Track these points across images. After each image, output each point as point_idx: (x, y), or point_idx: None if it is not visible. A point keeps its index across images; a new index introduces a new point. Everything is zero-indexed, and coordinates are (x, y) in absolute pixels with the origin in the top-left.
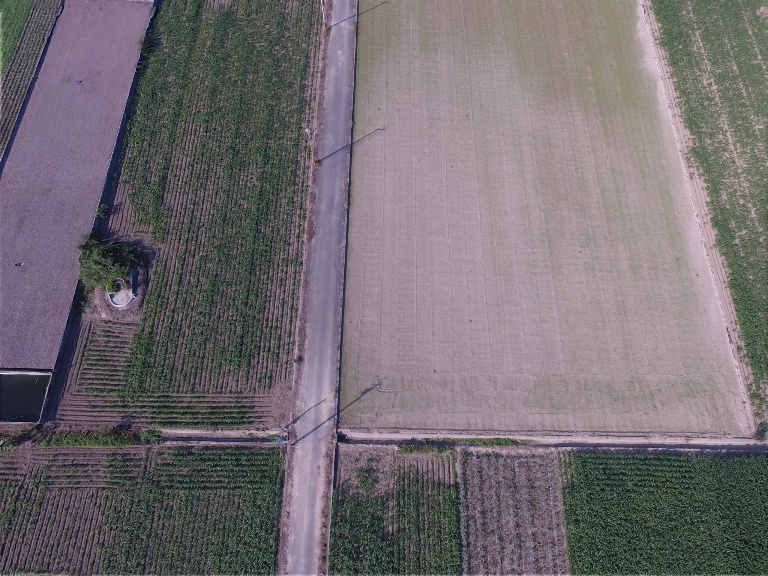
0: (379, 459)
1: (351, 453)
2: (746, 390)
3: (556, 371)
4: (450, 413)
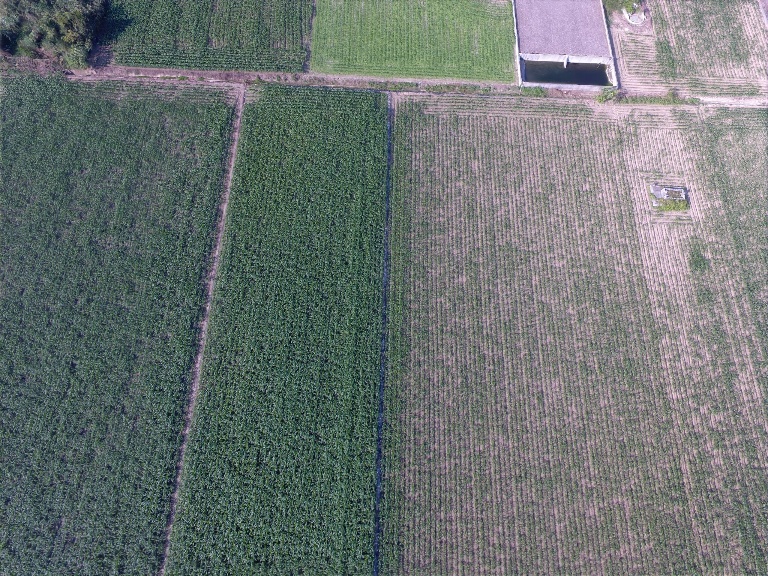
0: None
1: None
2: None
3: None
4: None
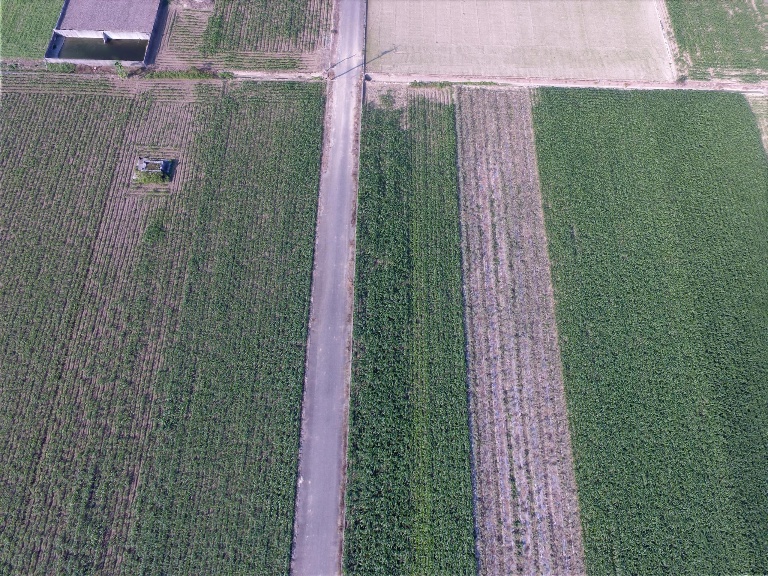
0: (396, 91)
1: (375, 87)
2: (672, 56)
3: (529, 44)
4: (448, 66)
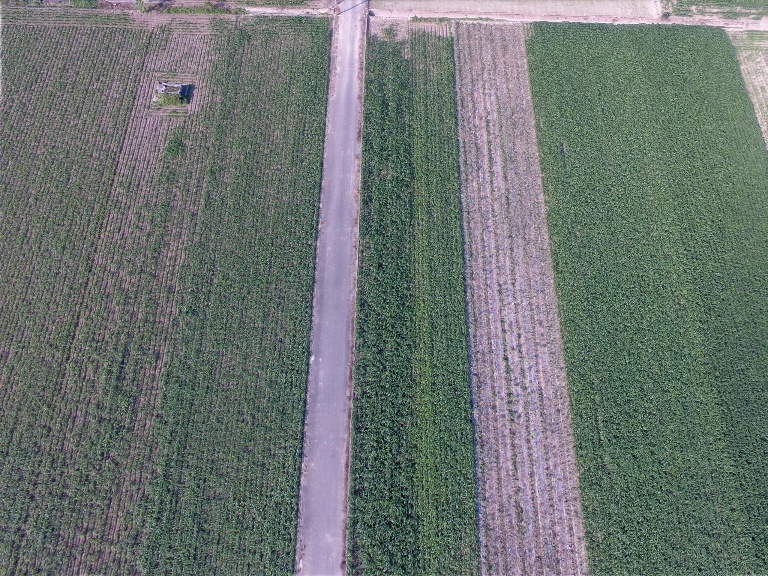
0: (398, 25)
1: (378, 22)
2: None
3: None
4: (447, 3)
